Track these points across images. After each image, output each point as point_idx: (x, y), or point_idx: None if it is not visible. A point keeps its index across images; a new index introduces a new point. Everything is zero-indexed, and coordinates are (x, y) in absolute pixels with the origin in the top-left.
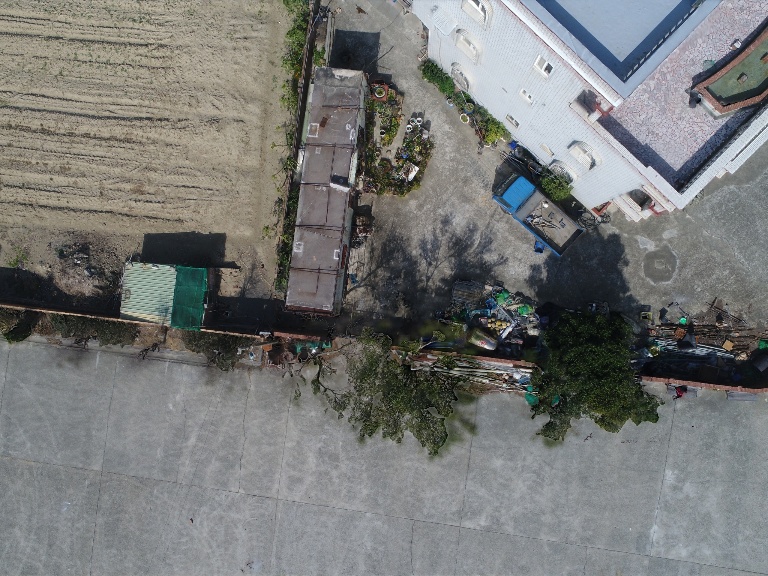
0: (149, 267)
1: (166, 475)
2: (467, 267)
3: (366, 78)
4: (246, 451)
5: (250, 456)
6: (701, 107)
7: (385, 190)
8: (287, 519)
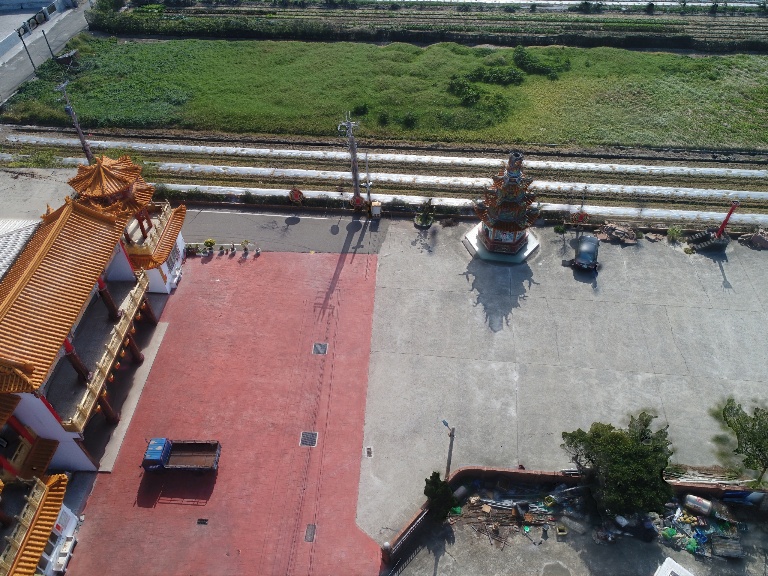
0: None
1: None
2: (736, 574)
3: None
4: None
5: None
6: None
7: None
8: None
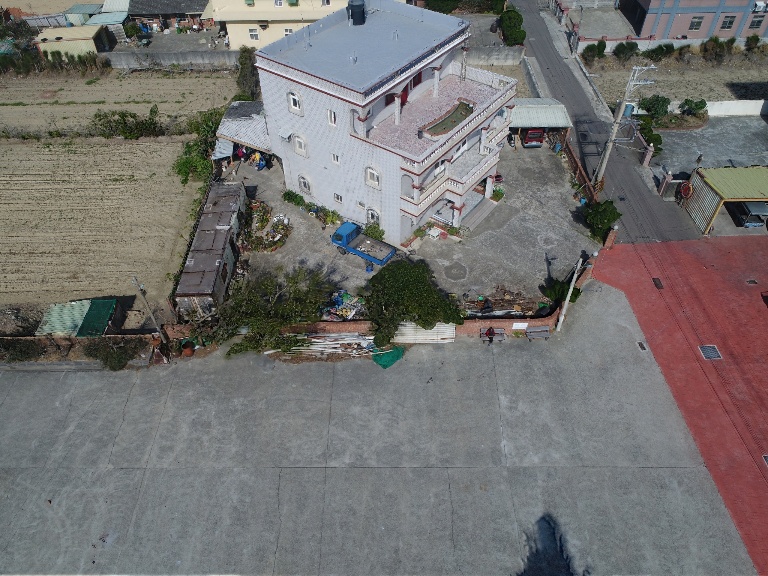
0: (69, 304)
1: (35, 462)
2: (319, 285)
3: (245, 191)
4: (122, 431)
5: (125, 434)
6: (425, 139)
7: (258, 248)
8: (153, 486)
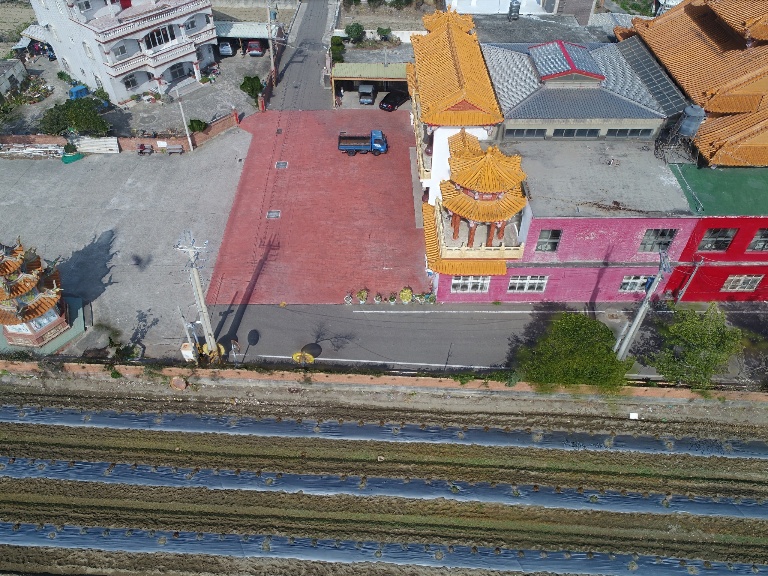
0: None
1: None
2: None
3: (25, 67)
4: None
5: None
6: None
7: (21, 101)
8: None
